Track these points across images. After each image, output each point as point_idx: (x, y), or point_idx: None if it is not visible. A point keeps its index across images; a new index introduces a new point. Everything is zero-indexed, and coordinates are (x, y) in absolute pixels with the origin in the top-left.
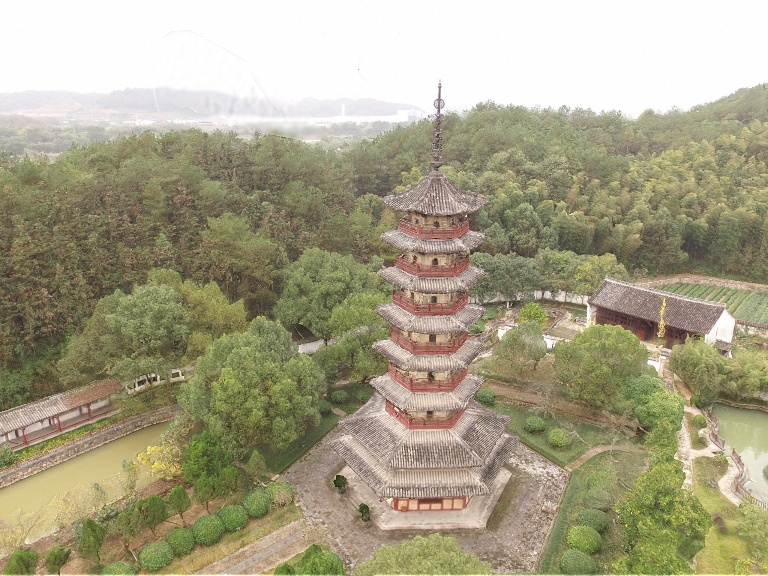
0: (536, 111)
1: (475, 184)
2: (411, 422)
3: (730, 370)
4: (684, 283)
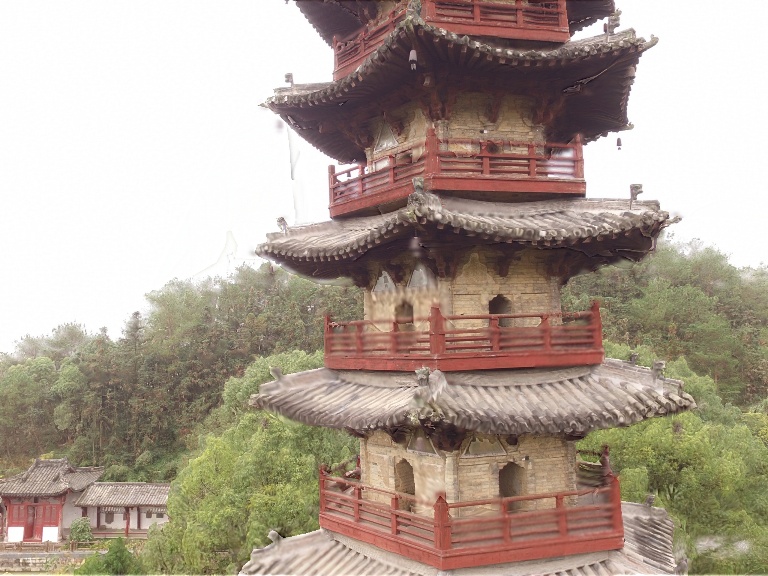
0: None
1: None
2: None
3: None
4: None
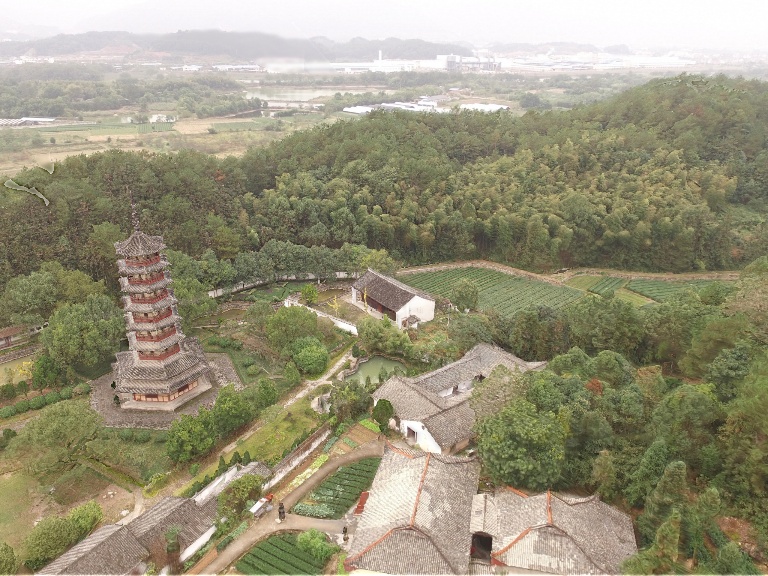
0: (425, 113)
1: (320, 189)
2: (140, 356)
3: (381, 336)
4: (474, 267)
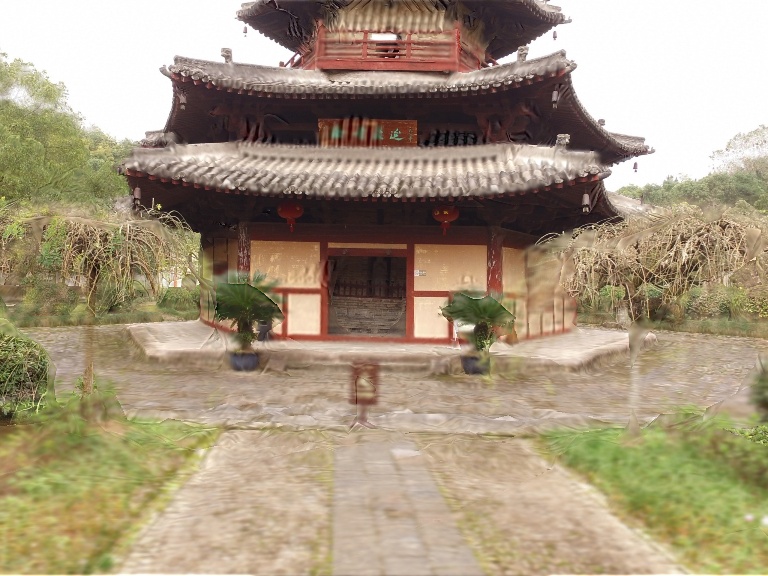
0: None
1: None
2: (459, 49)
3: None
4: None
